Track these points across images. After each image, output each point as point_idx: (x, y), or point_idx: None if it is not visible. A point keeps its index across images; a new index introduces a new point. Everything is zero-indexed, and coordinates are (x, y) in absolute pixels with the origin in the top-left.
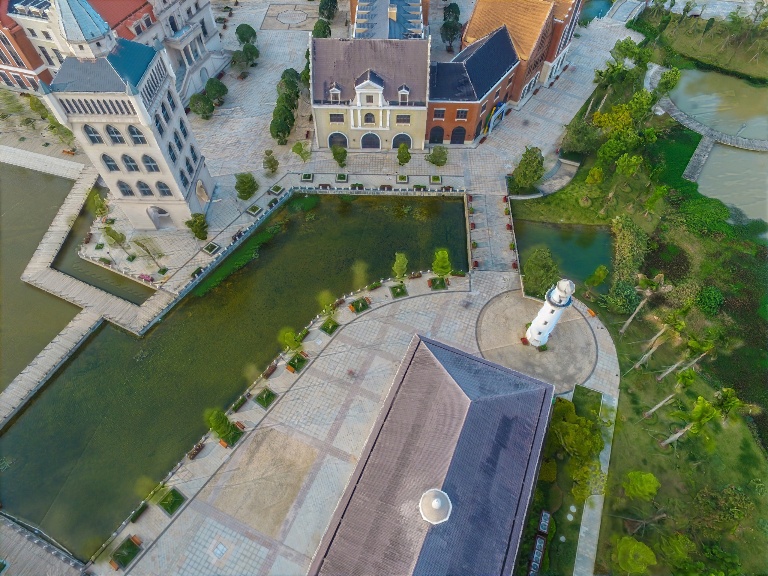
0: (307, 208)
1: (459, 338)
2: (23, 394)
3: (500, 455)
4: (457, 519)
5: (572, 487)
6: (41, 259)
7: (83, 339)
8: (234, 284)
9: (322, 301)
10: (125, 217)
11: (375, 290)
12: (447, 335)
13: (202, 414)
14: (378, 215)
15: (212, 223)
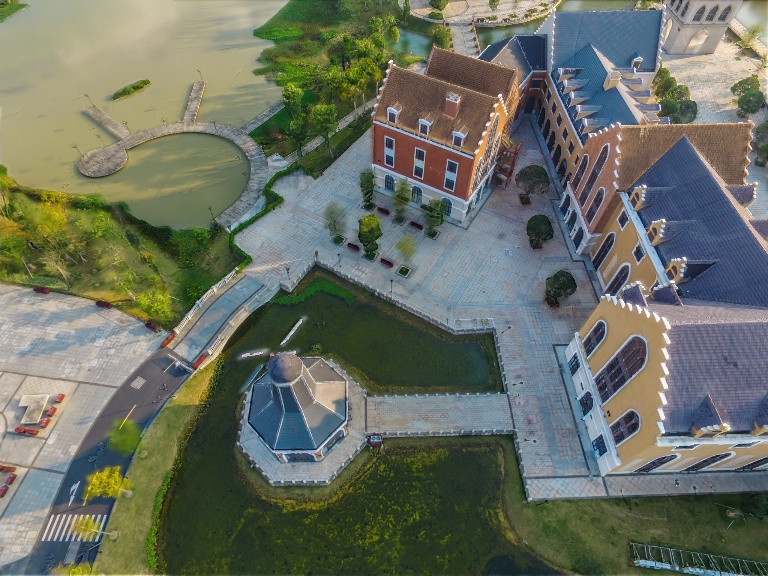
0: None
1: (477, 3)
2: None
3: None
4: None
5: None
6: None
7: None
8: None
9: None
10: None
11: None
12: (483, 4)
13: None
14: None
15: None
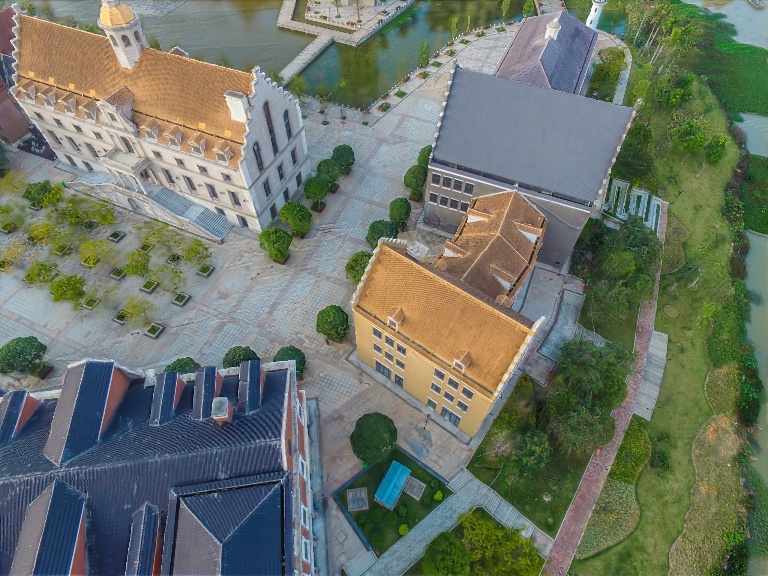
0: (435, 0)
1: None
2: (303, 62)
3: (576, 38)
4: (561, 44)
5: (608, 90)
6: (284, 17)
7: (324, 46)
8: (401, 29)
9: (455, 36)
10: (326, 1)
11: (487, 29)
12: None
13: (402, 72)
14: (480, 4)
15: (380, 4)
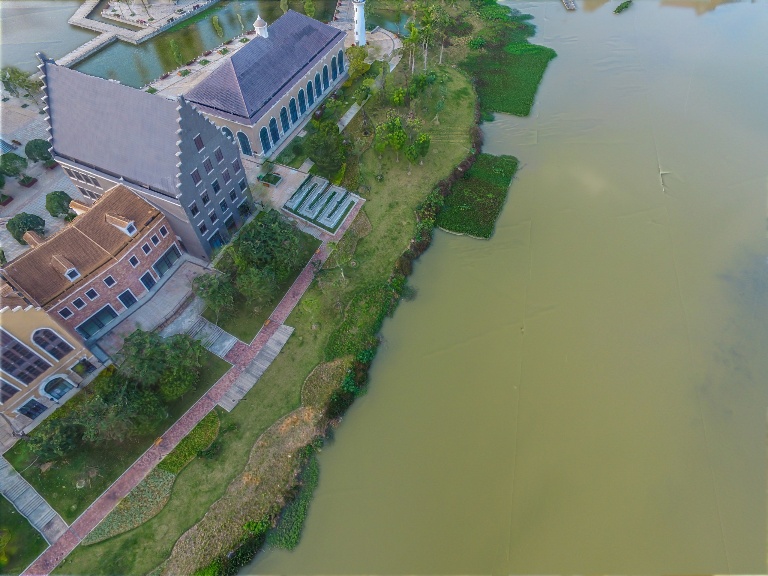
0: None
1: None
2: (73, 59)
3: (304, 37)
4: (274, 42)
5: None
6: (80, 15)
7: (105, 44)
8: (193, 28)
9: None
10: None
11: None
12: None
13: (169, 70)
14: None
15: (182, 3)
